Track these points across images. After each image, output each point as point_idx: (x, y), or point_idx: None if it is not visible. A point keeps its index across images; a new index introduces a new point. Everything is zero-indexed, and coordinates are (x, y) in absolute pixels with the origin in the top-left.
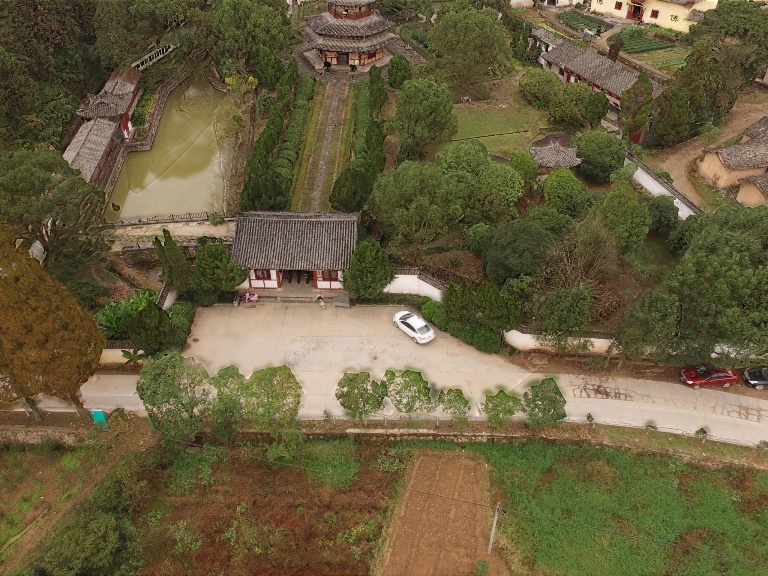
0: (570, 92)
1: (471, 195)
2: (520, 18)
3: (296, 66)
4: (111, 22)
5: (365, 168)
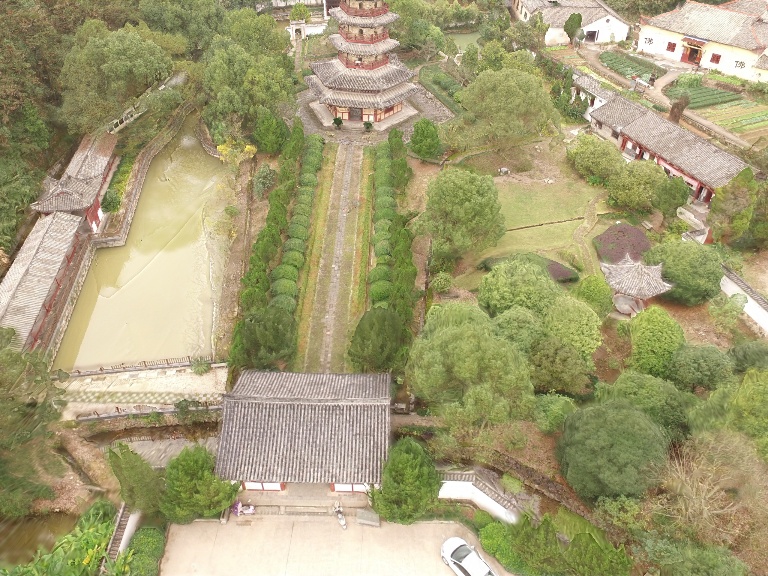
0: (637, 174)
1: (535, 346)
2: (557, 60)
3: (302, 130)
4: (79, 83)
5: (392, 293)
